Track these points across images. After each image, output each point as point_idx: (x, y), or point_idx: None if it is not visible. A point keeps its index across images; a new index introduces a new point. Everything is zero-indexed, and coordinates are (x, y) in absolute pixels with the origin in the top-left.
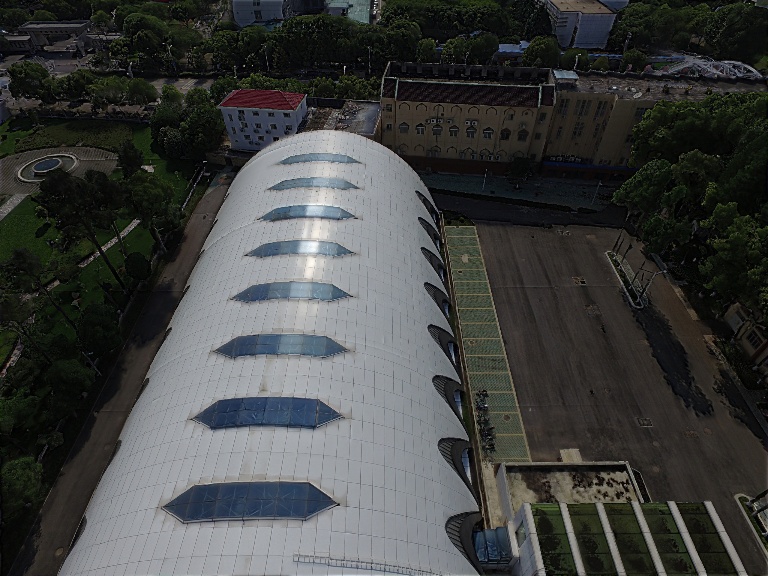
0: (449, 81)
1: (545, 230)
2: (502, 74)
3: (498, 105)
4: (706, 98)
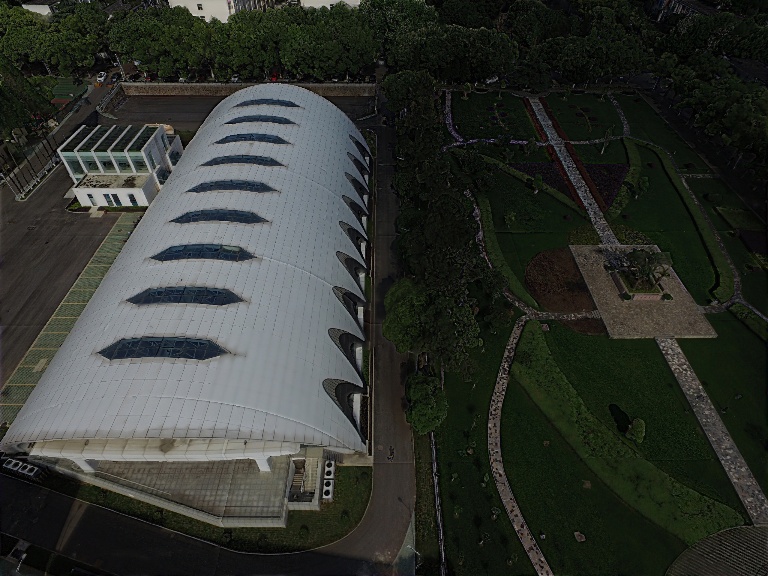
0: None
1: None
2: None
3: None
4: None
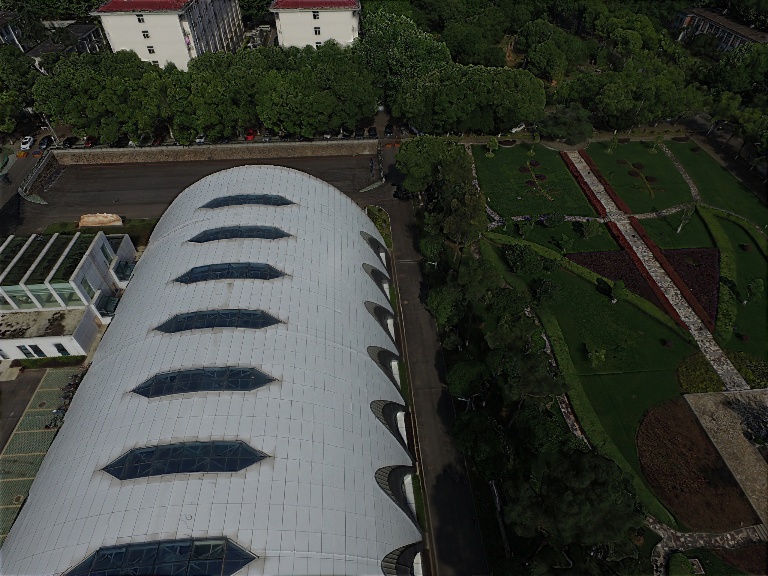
0: None
1: None
2: None
3: None
4: None
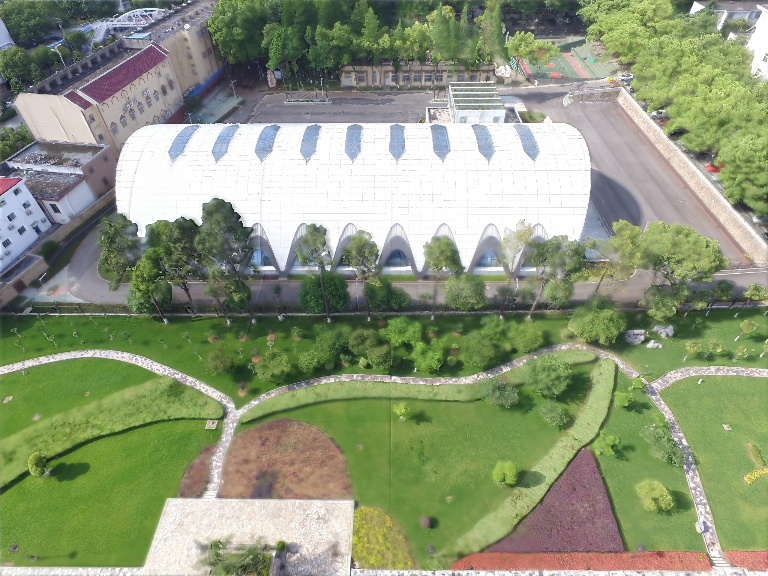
0: (84, 80)
1: (255, 118)
2: (100, 59)
3: (151, 68)
4: (220, 8)
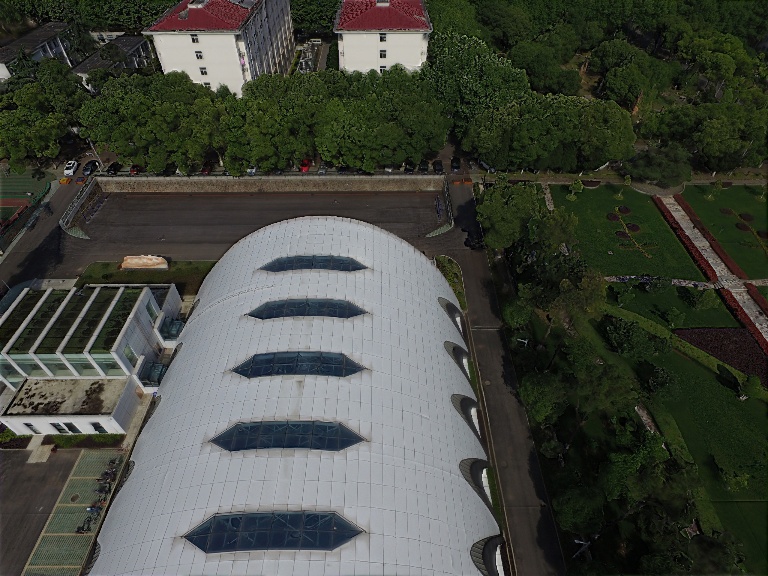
0: None
1: None
2: None
3: None
4: None
